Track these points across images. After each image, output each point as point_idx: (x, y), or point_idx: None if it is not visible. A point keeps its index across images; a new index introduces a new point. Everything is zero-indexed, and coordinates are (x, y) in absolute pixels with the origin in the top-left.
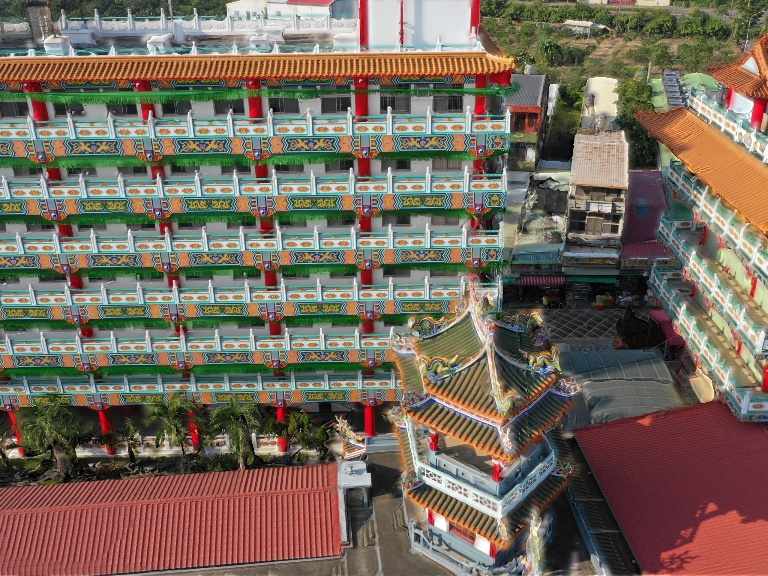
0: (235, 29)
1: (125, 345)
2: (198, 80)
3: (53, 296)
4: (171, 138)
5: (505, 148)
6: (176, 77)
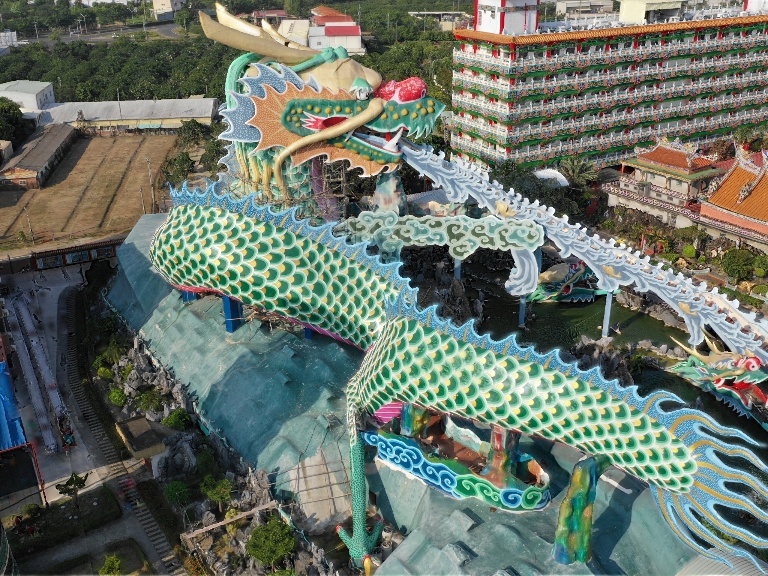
0: (704, 13)
1: (723, 120)
2: (757, 23)
3: (711, 102)
4: (754, 41)
5: None
6: (760, 21)
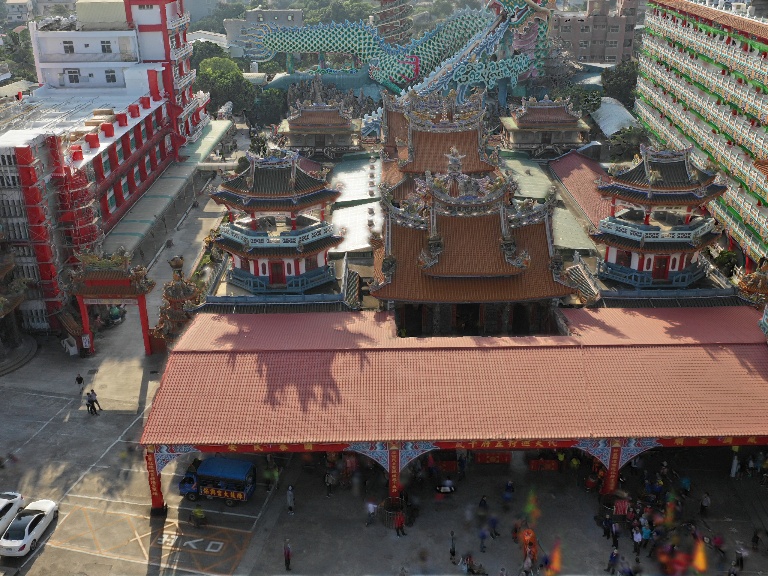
0: None
1: None
2: None
3: None
4: None
5: None
6: None
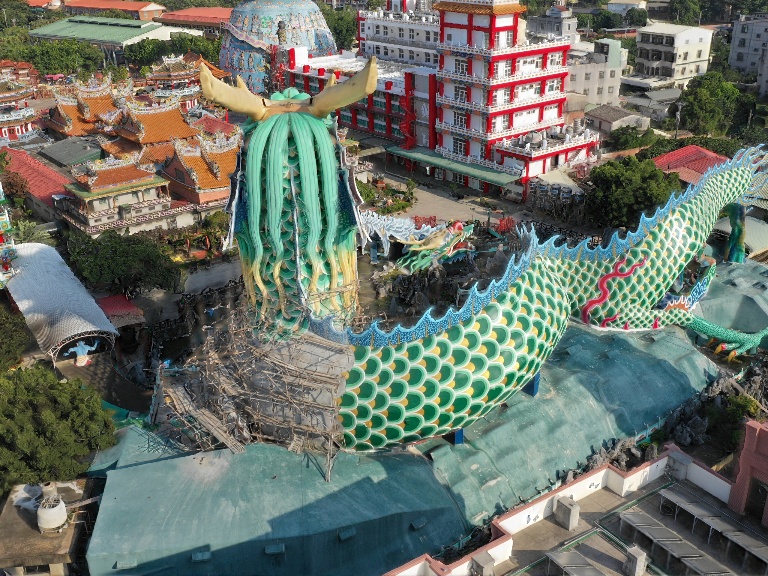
0: None
1: None
2: None
3: None
4: None
5: None
6: None
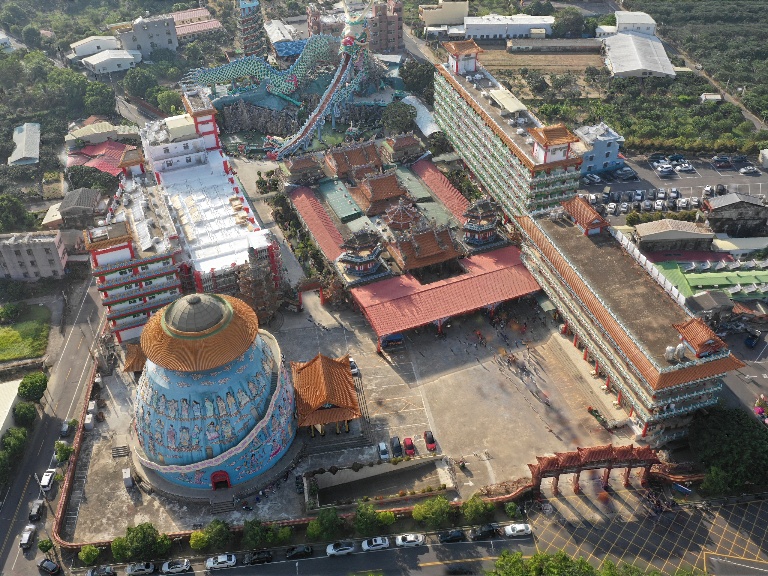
0: None
1: None
2: None
3: None
4: None
5: (530, 185)
6: None
